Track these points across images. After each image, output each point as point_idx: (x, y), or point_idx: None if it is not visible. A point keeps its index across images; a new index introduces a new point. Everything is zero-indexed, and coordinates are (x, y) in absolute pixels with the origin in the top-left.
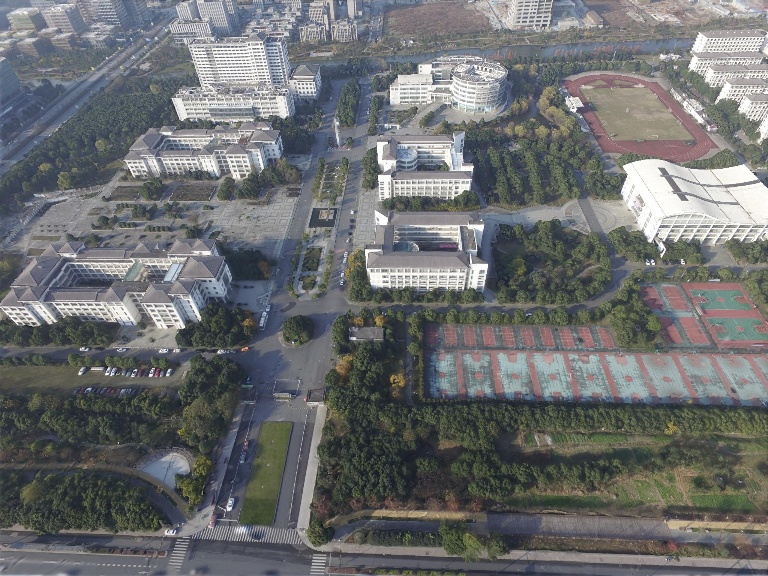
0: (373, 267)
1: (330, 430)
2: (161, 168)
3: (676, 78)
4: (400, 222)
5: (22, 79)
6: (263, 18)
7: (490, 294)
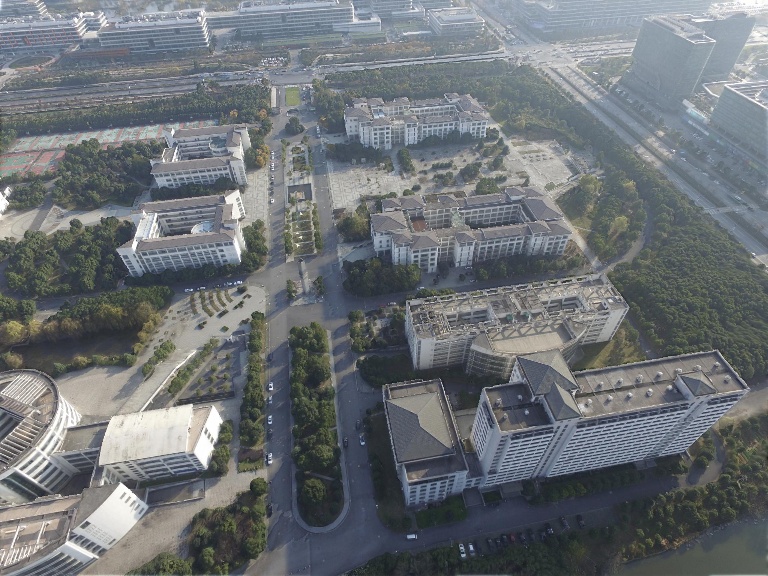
0: None
1: None
2: None
3: None
4: None
5: None
6: None
7: None
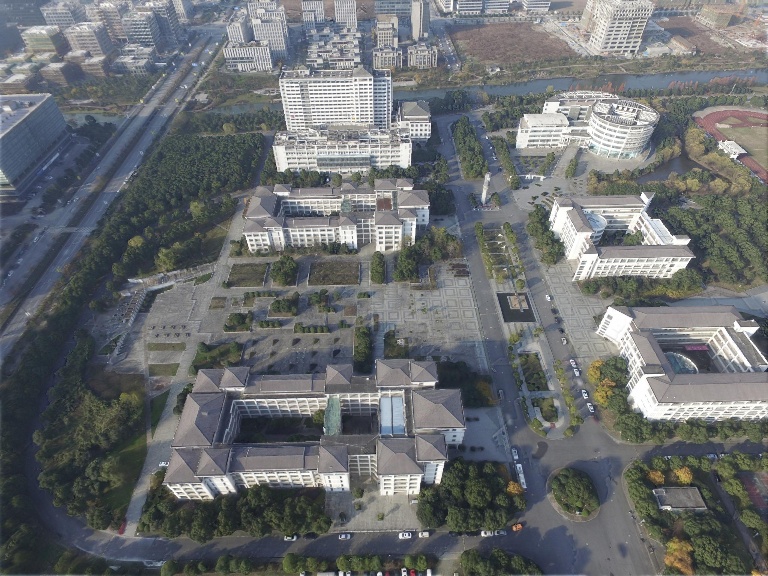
0: (666, 401)
1: None
2: (285, 240)
3: None
4: (649, 324)
5: None
6: (322, 40)
7: None
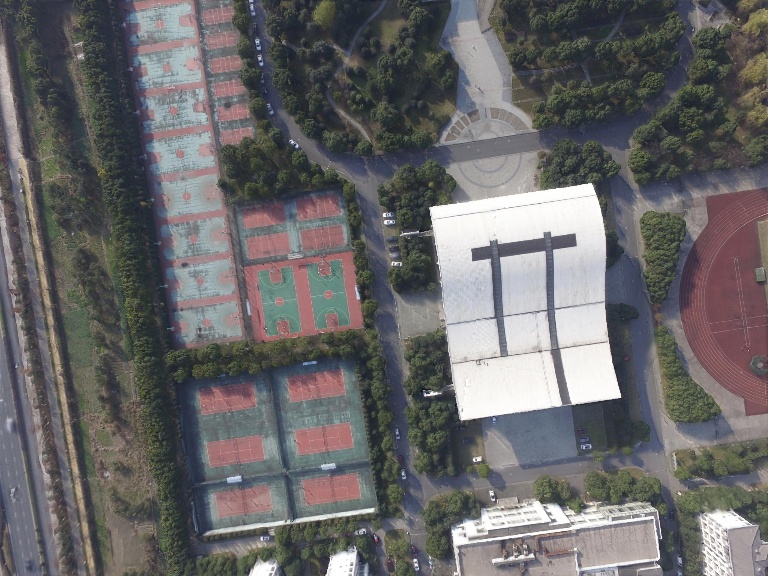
0: None
1: None
2: None
3: None
4: None
5: None
6: None
7: None
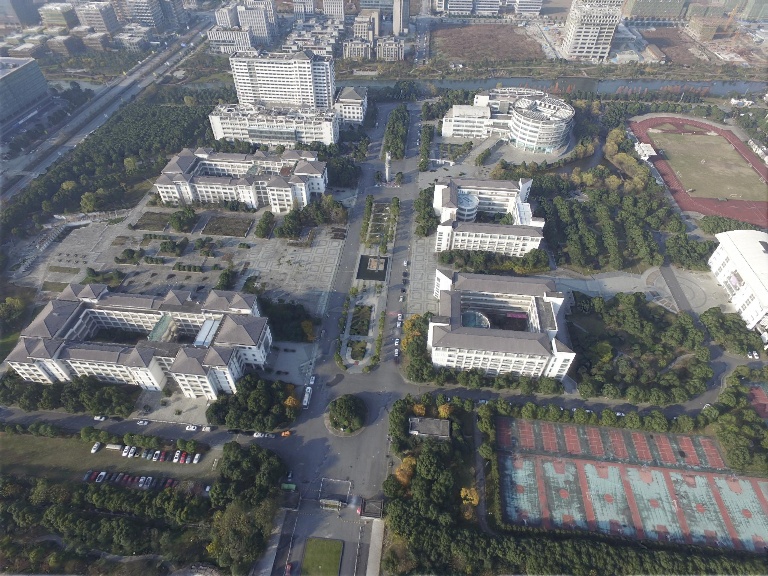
0: (440, 346)
1: (393, 564)
2: (194, 195)
3: (754, 128)
4: (466, 287)
5: (50, 79)
6: (304, 30)
7: (569, 382)
